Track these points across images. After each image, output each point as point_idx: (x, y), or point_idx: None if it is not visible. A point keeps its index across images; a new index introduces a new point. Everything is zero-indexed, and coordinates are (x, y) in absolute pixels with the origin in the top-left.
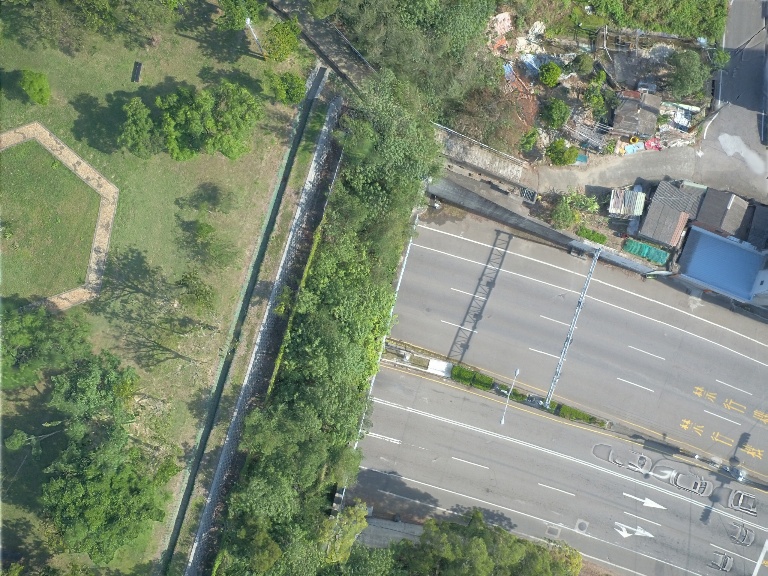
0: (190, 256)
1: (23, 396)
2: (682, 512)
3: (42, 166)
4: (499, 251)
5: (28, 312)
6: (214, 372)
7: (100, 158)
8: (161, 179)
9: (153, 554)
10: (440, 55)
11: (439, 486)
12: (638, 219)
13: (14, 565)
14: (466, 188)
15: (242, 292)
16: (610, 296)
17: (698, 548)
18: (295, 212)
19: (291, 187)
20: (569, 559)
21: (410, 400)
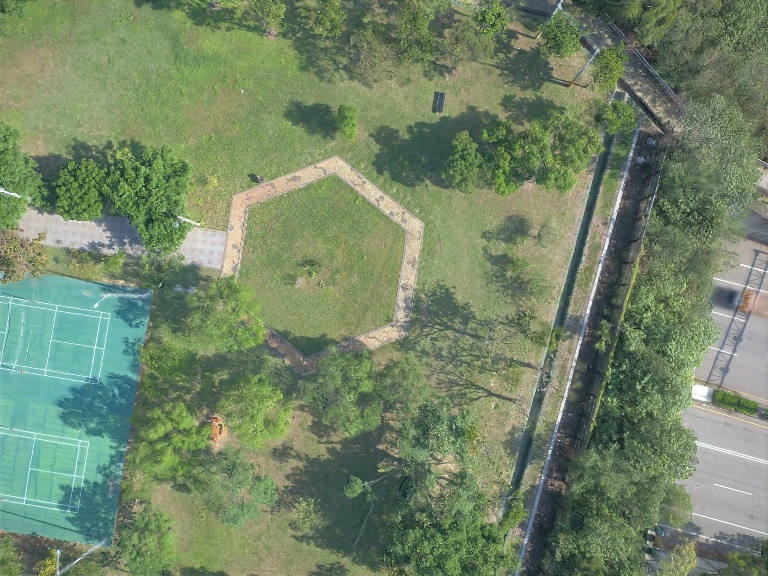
0: (500, 291)
1: (334, 438)
2: None
3: (345, 202)
4: (758, 271)
5: (337, 352)
6: (526, 410)
7: (404, 192)
8: (467, 212)
9: None
10: (761, 78)
11: (702, 513)
12: None
13: None
14: (754, 211)
15: (551, 327)
16: None
17: None
18: (603, 243)
19: (598, 217)
20: None
21: None
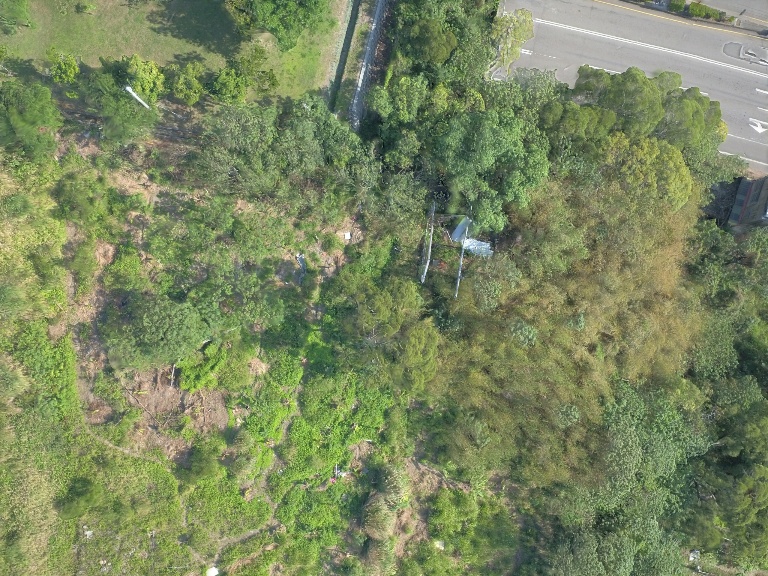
0: None
1: None
2: None
3: None
4: None
5: None
6: None
7: None
8: None
9: (322, 81)
10: None
11: None
12: None
13: None
14: None
15: None
16: None
17: None
18: None
19: None
20: None
21: (539, 11)
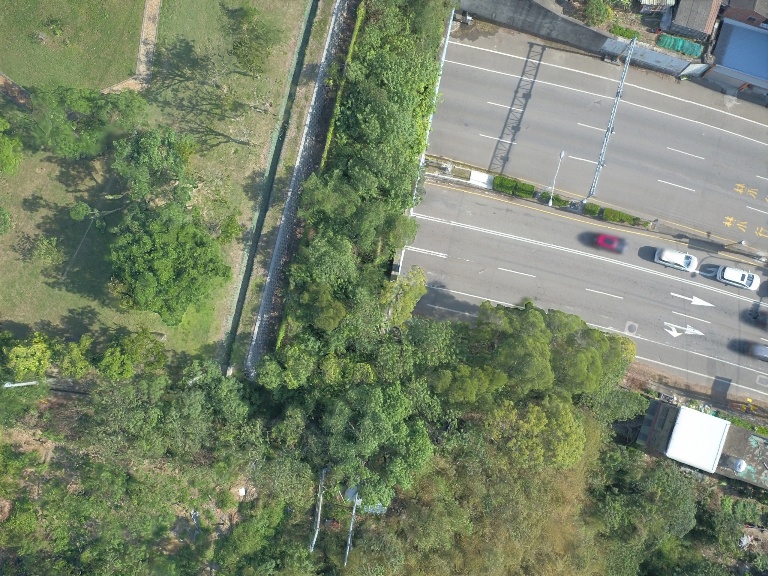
0: None
1: (82, 187)
2: (730, 309)
3: None
4: (533, 63)
5: None
6: (266, 155)
7: None
8: None
9: (217, 335)
10: None
11: (487, 297)
12: (670, 14)
13: (85, 336)
14: None
15: (289, 77)
16: (646, 100)
17: (749, 342)
18: None
19: None
20: (623, 345)
21: (454, 214)
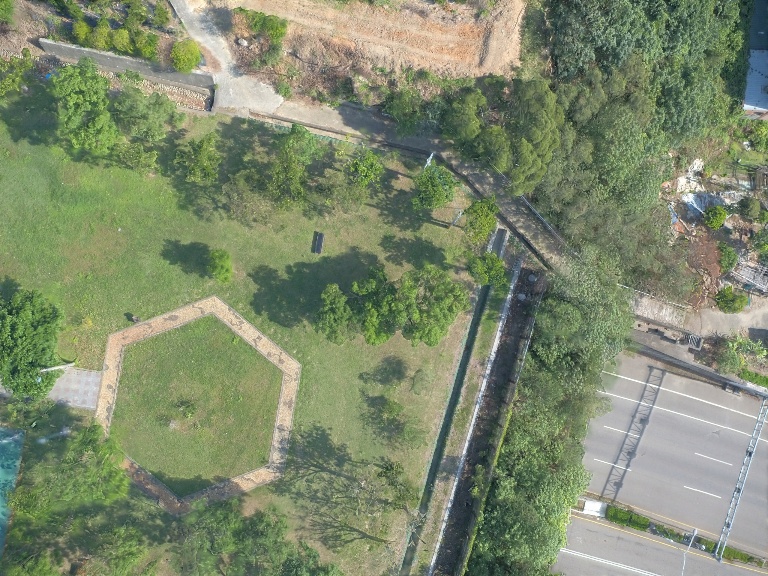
0: (376, 433)
1: None
2: None
3: (222, 342)
4: (652, 388)
5: (212, 494)
6: (402, 550)
7: (281, 333)
8: (344, 353)
9: None
10: (634, 227)
11: None
12: None
13: None
14: (639, 342)
15: (428, 467)
16: (765, 432)
17: None
18: (481, 384)
19: (476, 358)
20: None
21: None
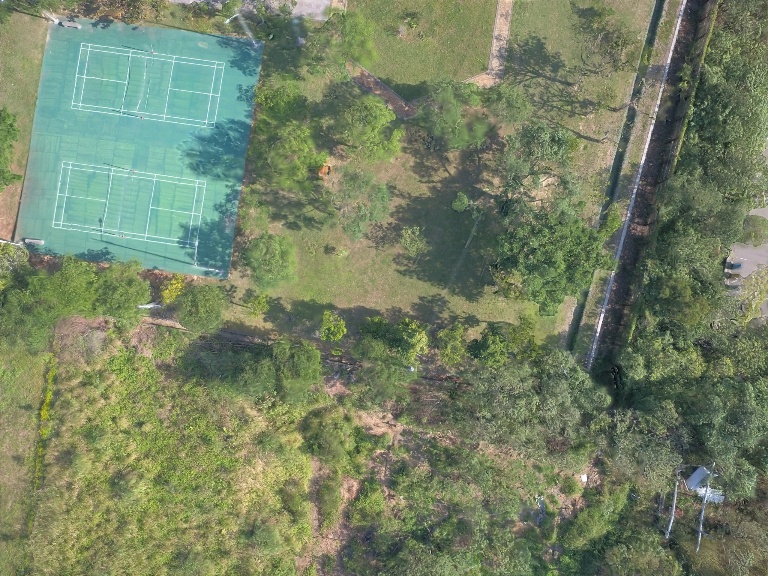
0: (587, 41)
1: (435, 178)
2: None
3: None
4: None
5: (436, 98)
6: (612, 152)
7: None
8: None
9: (562, 326)
10: None
11: None
12: None
13: (459, 323)
14: None
15: (635, 76)
16: None
17: None
18: None
19: None
20: None
21: None
